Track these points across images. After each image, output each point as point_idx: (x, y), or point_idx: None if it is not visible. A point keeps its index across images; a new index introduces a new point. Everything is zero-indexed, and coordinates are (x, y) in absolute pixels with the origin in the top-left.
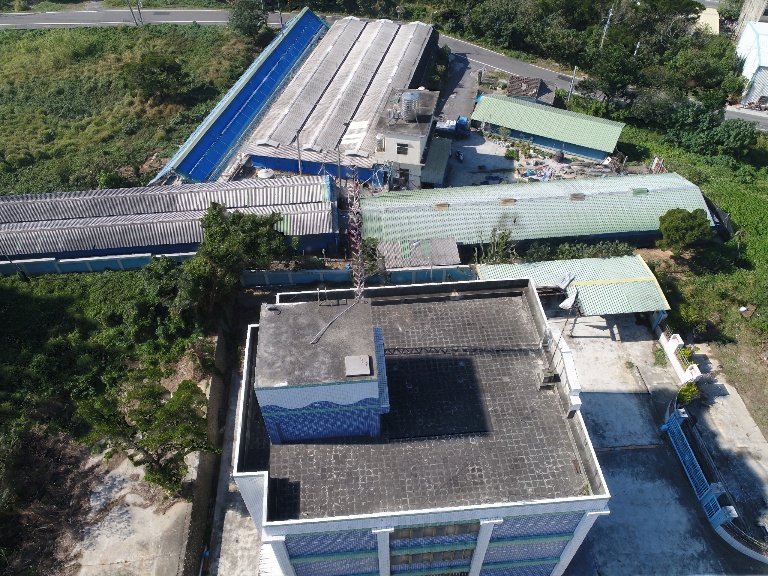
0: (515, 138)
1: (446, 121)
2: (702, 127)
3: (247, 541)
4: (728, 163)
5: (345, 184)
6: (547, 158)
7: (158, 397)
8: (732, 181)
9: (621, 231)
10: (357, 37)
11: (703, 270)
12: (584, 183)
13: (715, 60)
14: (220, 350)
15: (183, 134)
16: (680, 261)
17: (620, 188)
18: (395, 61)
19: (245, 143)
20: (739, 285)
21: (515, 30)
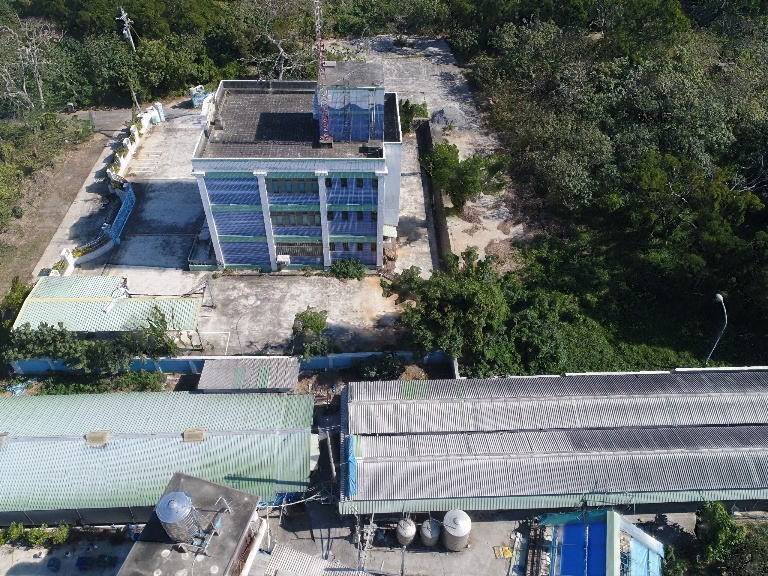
0: None
1: None
2: None
3: (410, 207)
4: None
5: None
6: None
7: (465, 173)
8: None
9: None
10: None
11: None
12: None
13: None
14: None
15: None
16: None
17: None
18: None
19: None
20: None
21: None
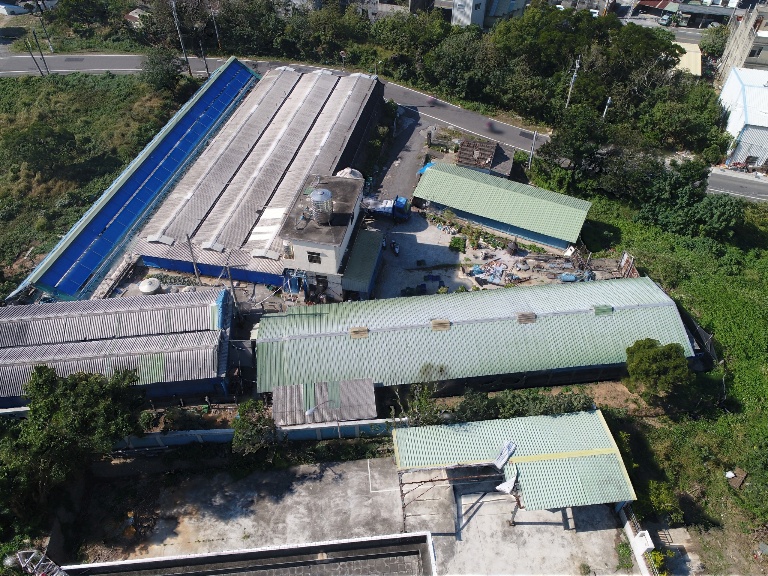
0: (465, 218)
1: (383, 201)
2: (681, 203)
3: None
4: (711, 248)
5: (253, 290)
6: (499, 249)
7: None
8: (716, 272)
9: (580, 365)
10: (289, 92)
11: (681, 414)
12: (537, 294)
13: (696, 114)
14: (52, 557)
15: (69, 220)
16: (653, 401)
17: (580, 304)
18: (327, 125)
19: (135, 238)
20: (725, 439)
21: (472, 79)
